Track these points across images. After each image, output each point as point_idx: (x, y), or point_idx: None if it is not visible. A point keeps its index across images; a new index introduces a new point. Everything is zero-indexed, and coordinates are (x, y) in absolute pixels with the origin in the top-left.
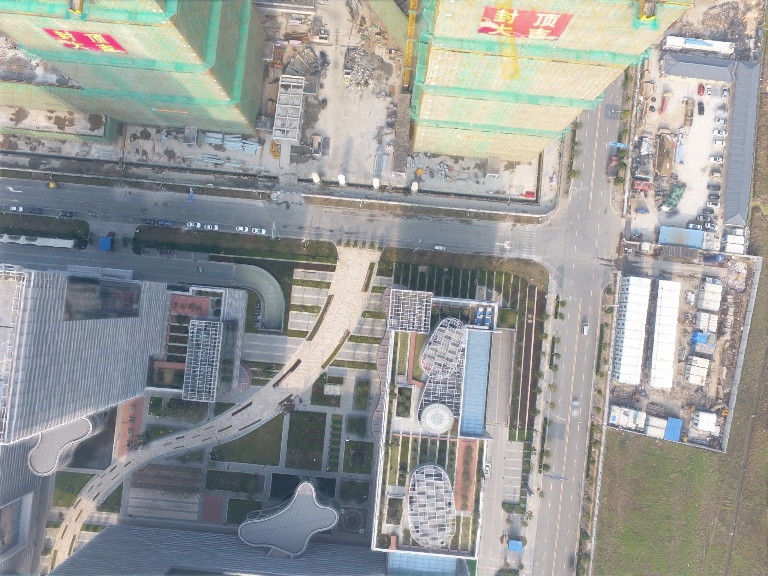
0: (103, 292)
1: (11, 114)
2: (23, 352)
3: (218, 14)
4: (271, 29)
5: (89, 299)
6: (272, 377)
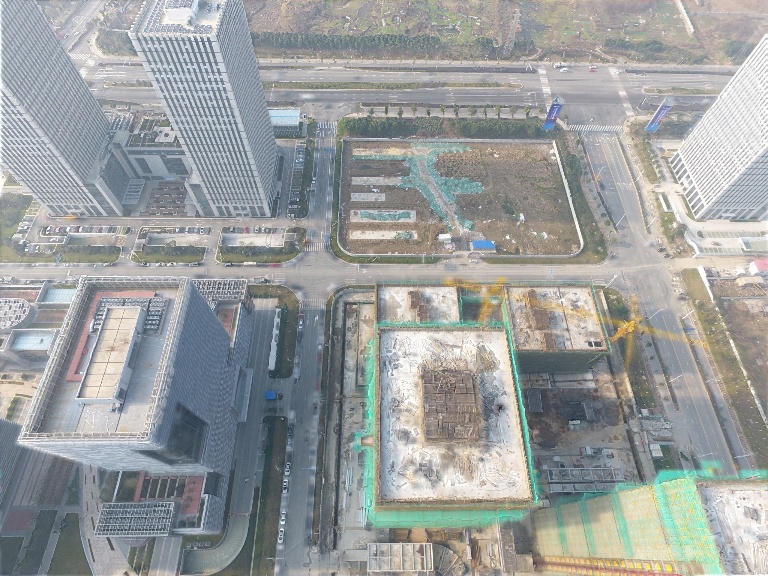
0: (178, 449)
1: (369, 316)
2: (88, 442)
3: (421, 523)
4: (478, 523)
5: (163, 448)
6: (135, 569)
